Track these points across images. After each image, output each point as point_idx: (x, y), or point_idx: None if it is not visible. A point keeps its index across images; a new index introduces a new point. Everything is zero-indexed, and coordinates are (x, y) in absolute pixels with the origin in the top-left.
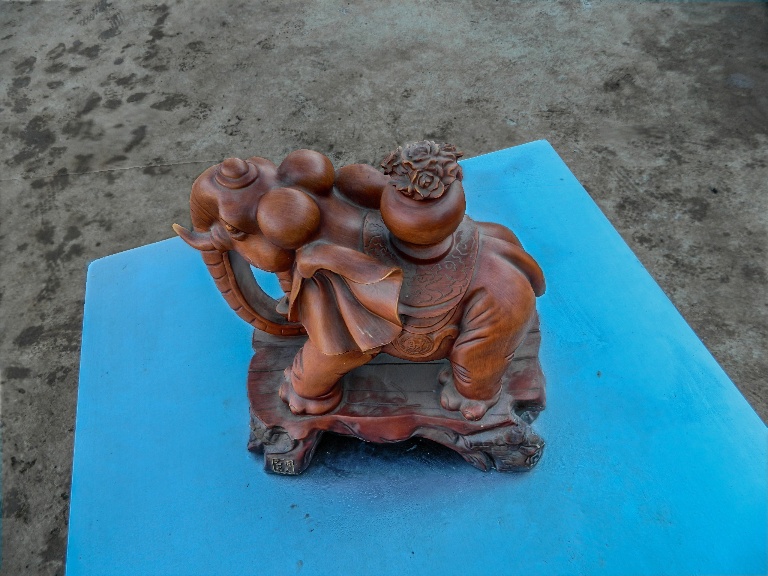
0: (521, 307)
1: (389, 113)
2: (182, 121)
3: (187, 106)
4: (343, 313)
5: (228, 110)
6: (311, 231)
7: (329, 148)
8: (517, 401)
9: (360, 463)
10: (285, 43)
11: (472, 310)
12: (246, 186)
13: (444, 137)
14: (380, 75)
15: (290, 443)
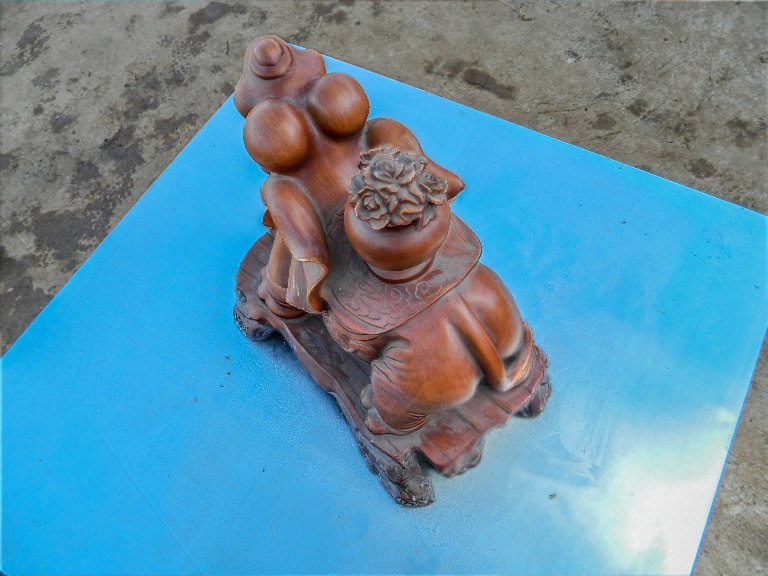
0: (436, 388)
1: (724, 67)
2: None
3: None
4: (292, 255)
5: None
6: (281, 165)
7: (624, 65)
8: (421, 450)
9: (296, 373)
10: None
11: (393, 350)
12: (265, 78)
13: (755, 135)
14: (760, 15)
15: None
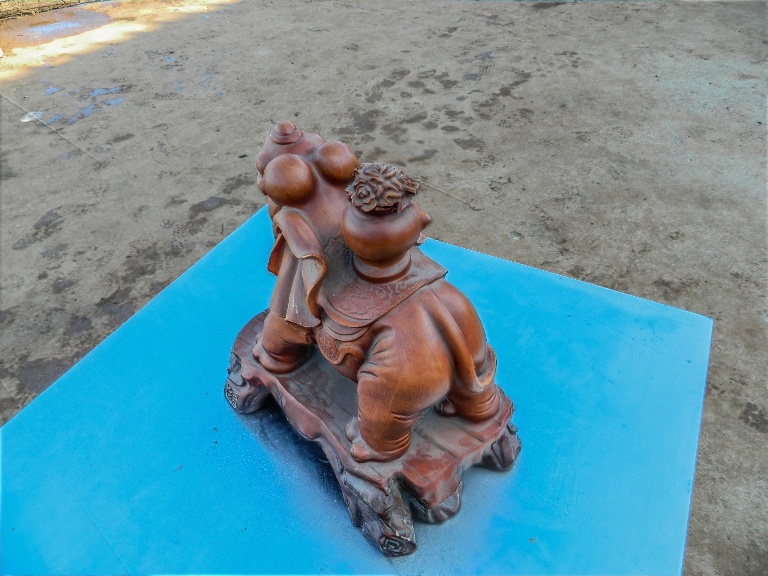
0: (416, 369)
1: (642, 242)
2: (466, 161)
3: (479, 152)
4: None
5: (507, 170)
6: (292, 196)
7: (561, 241)
8: (403, 475)
9: (282, 440)
10: (600, 142)
11: (378, 344)
12: (282, 144)
13: (678, 291)
14: (664, 208)
15: (241, 378)
